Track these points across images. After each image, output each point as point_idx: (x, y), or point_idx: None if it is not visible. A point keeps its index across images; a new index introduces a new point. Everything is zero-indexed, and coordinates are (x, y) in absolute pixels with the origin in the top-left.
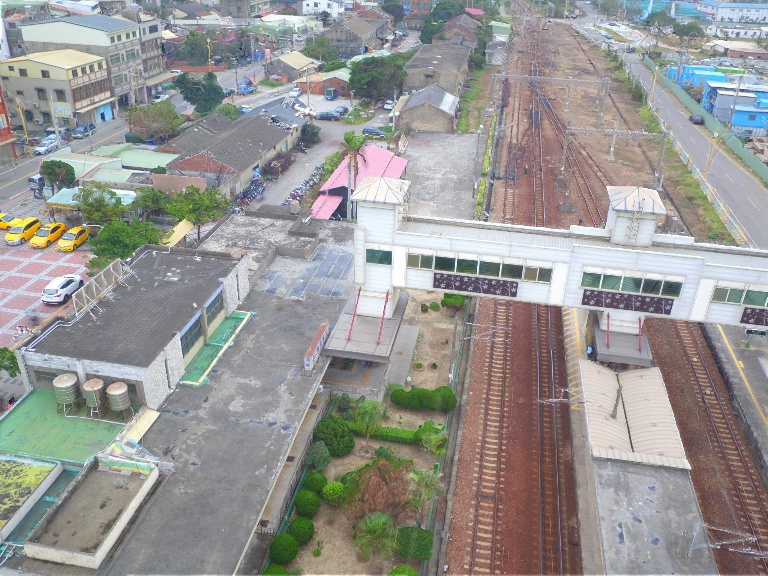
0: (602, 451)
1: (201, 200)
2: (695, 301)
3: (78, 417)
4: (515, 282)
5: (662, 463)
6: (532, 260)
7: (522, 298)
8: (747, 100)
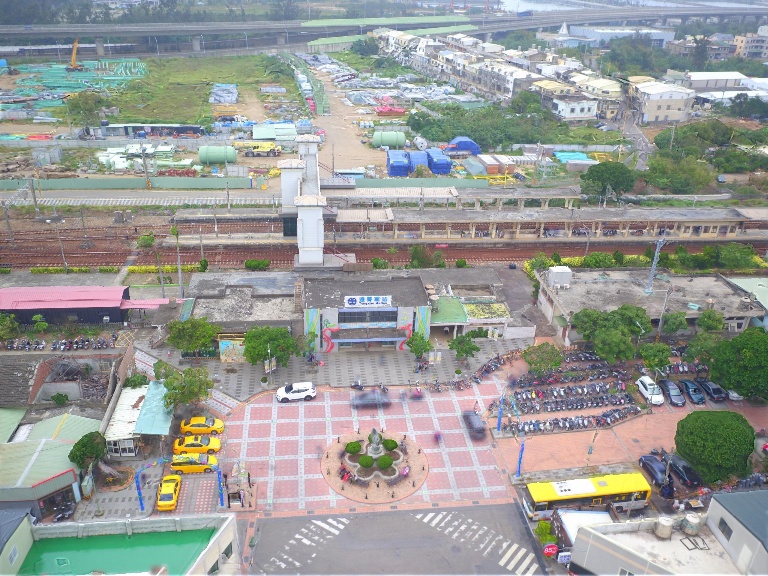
0: (391, 218)
1: None
2: None
3: None
4: None
5: None
6: None
7: None
8: None
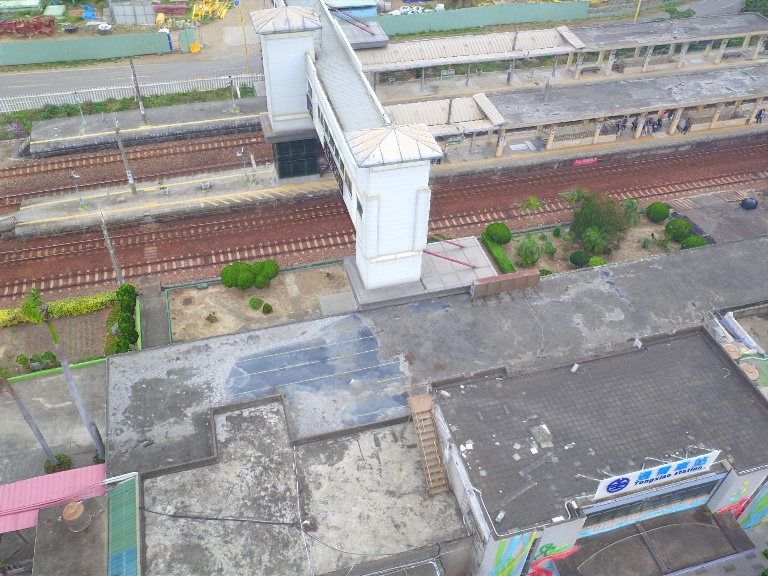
0: (497, 120)
1: None
2: None
3: None
4: None
5: None
6: None
7: None
8: None
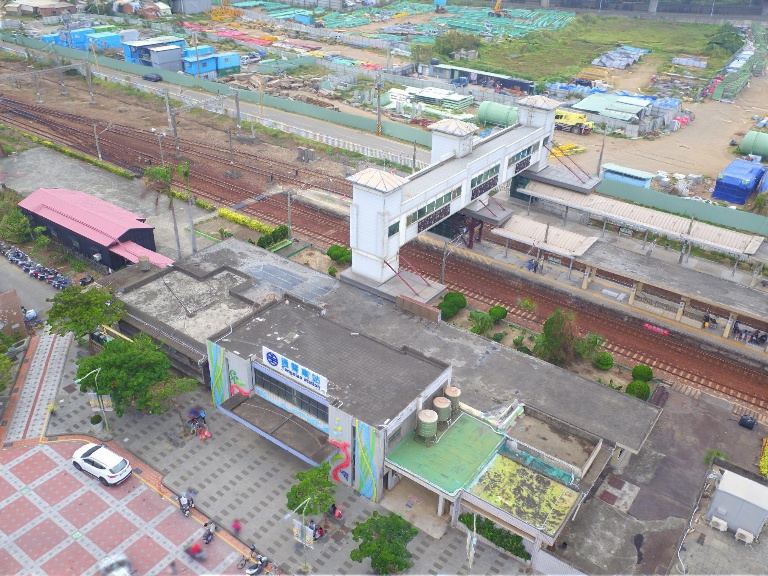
0: (577, 253)
1: (95, 299)
2: (503, 171)
3: (441, 436)
4: (449, 204)
5: (593, 242)
6: (455, 185)
7: (451, 213)
8: (176, 52)
